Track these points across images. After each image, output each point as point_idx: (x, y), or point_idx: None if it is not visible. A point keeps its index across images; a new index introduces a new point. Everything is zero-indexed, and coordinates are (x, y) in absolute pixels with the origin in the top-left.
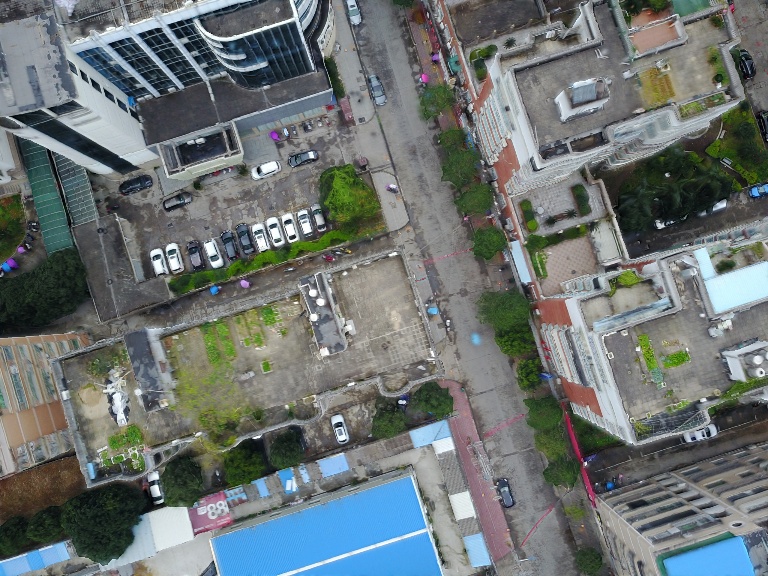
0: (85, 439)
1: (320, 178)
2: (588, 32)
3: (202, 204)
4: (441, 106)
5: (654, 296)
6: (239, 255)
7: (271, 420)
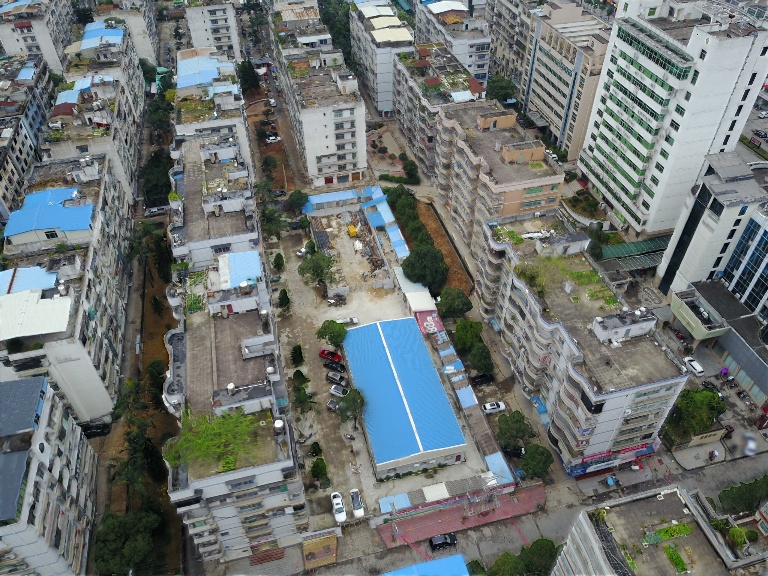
0: (511, 223)
1: None
2: None
3: None
4: None
5: None
6: None
7: None
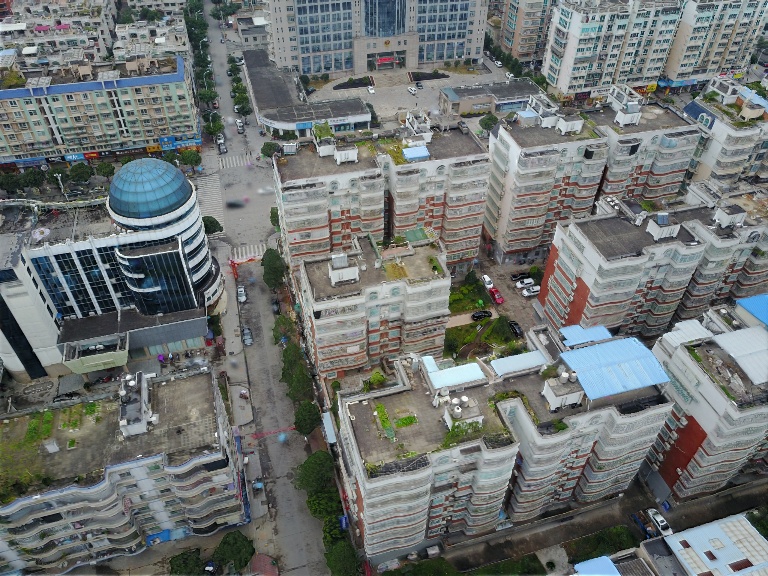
0: None
1: None
2: None
3: None
4: (284, 331)
5: None
6: None
7: None
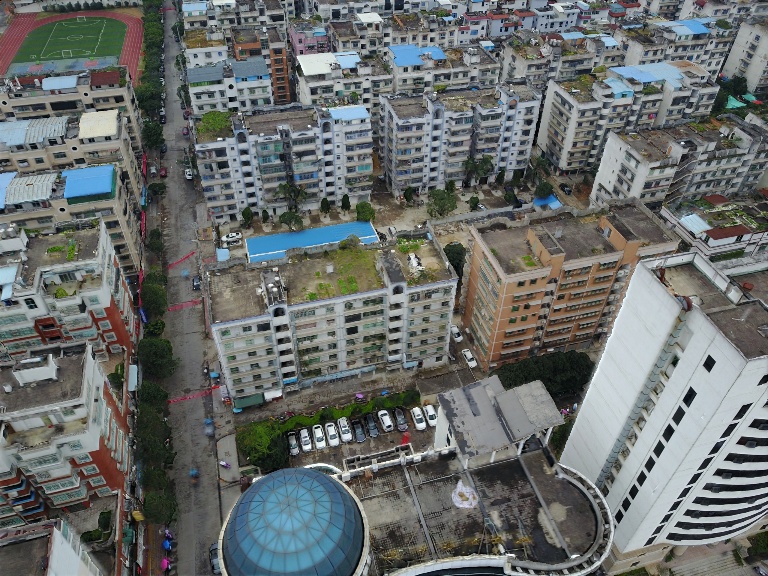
0: (435, 249)
1: None
2: (2, 430)
3: None
4: None
5: (49, 291)
6: None
7: (320, 255)
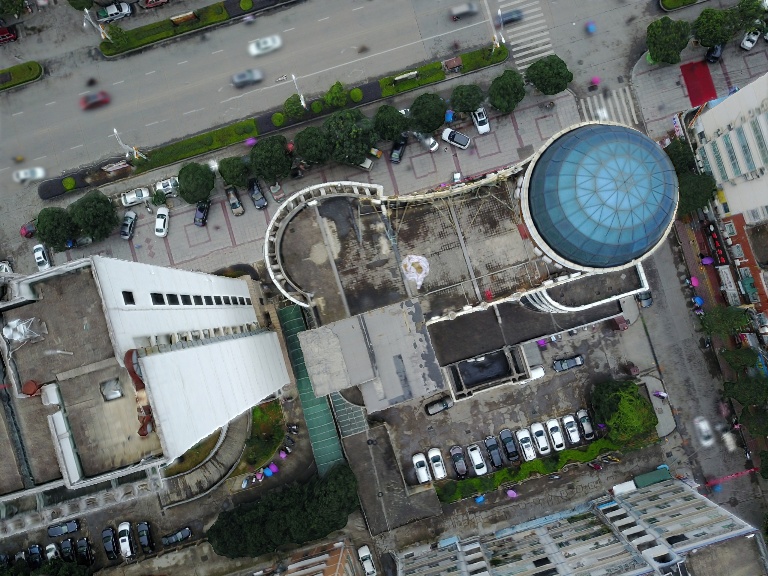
0: None
1: (598, 393)
2: None
3: (463, 407)
4: None
5: None
6: (503, 461)
7: None
